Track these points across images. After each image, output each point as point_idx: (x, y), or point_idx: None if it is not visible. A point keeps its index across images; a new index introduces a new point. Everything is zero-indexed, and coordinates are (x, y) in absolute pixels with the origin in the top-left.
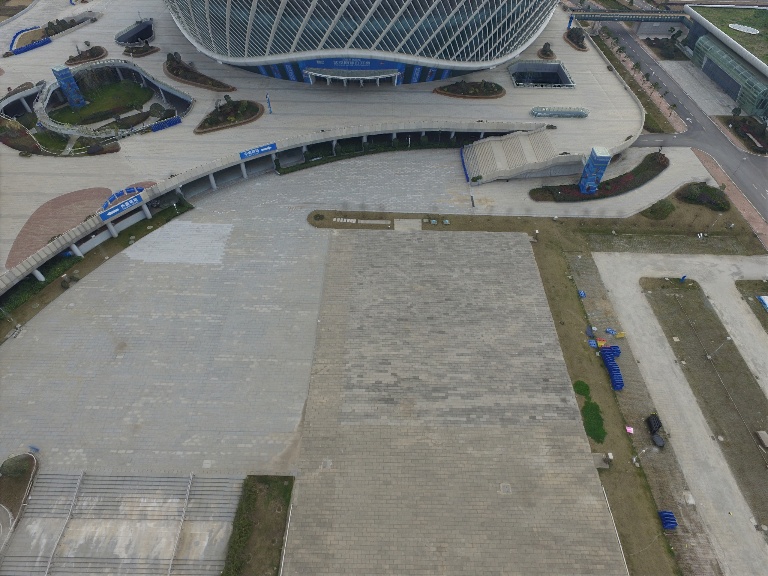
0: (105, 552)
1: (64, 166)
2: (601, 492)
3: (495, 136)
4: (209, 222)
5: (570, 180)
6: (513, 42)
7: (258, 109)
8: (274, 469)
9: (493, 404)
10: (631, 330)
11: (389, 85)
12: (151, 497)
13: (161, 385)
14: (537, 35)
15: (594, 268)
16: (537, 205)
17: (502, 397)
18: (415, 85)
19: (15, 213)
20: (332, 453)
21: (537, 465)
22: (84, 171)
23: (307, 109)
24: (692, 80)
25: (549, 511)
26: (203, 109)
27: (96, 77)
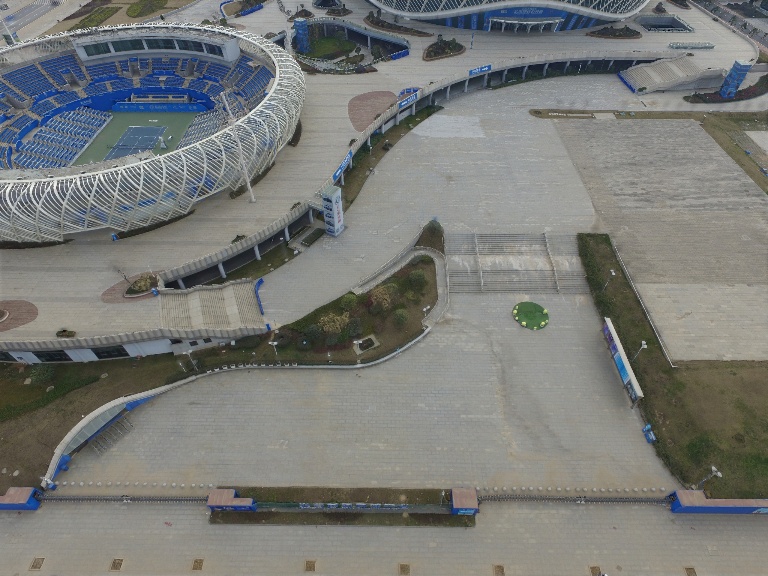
0: (508, 268)
1: (345, 79)
2: None
3: (646, 63)
4: (460, 116)
5: (710, 91)
6: None
7: (462, 46)
8: (592, 231)
9: (717, 202)
10: None
11: (549, 31)
12: (521, 244)
13: (491, 195)
14: None
15: (750, 139)
16: (693, 105)
17: (722, 199)
18: (569, 31)
19: (336, 104)
20: (625, 224)
21: (761, 228)
22: (363, 82)
23: (497, 46)
24: None
25: None
26: (418, 47)
27: (317, 29)
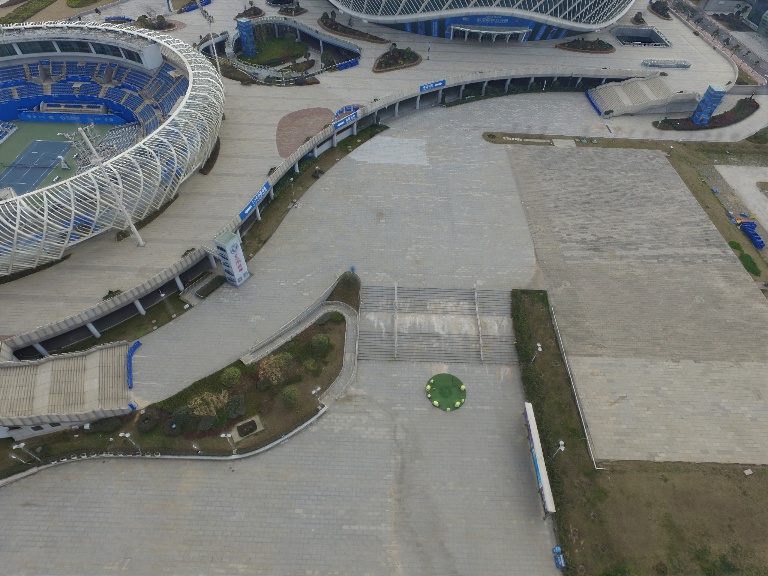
0: (429, 330)
1: (282, 92)
2: (767, 302)
3: (616, 81)
4: (406, 138)
5: (682, 116)
6: (617, 8)
7: (418, 56)
8: (530, 286)
9: (673, 253)
10: (759, 214)
11: (516, 42)
12: (447, 301)
13: (423, 238)
14: (630, 5)
15: (719, 175)
16: (662, 132)
17: (678, 249)
18: (538, 42)
19: (264, 123)
20: (568, 278)
21: (717, 287)
22: (300, 96)
23: (457, 57)
24: (761, 47)
25: (734, 311)
26: (371, 55)
27: (265, 30)
